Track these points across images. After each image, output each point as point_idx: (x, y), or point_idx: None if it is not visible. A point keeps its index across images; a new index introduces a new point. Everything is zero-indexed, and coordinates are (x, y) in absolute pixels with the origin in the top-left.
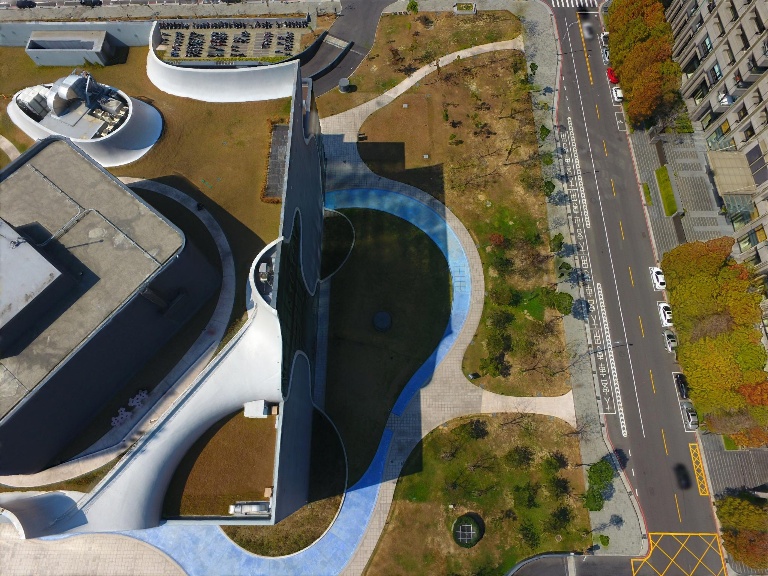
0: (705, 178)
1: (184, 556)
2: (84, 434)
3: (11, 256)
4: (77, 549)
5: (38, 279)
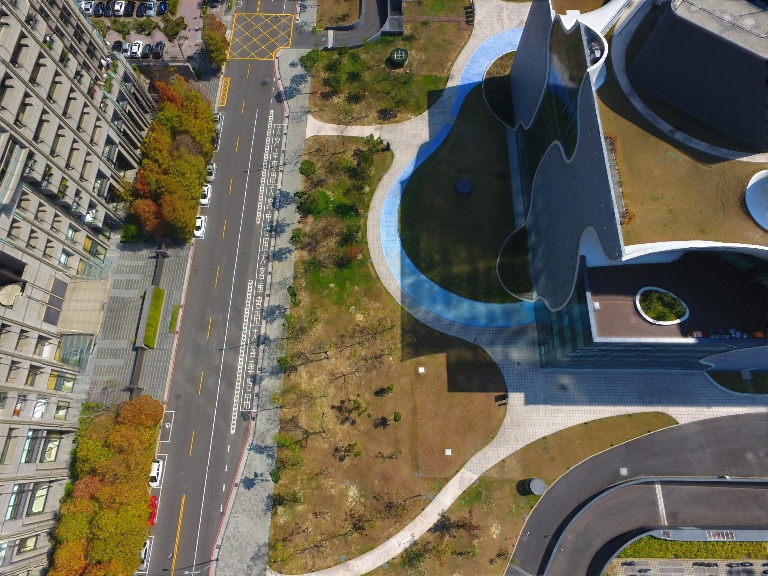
0: (100, 337)
1: None
2: None
3: None
4: None
5: None
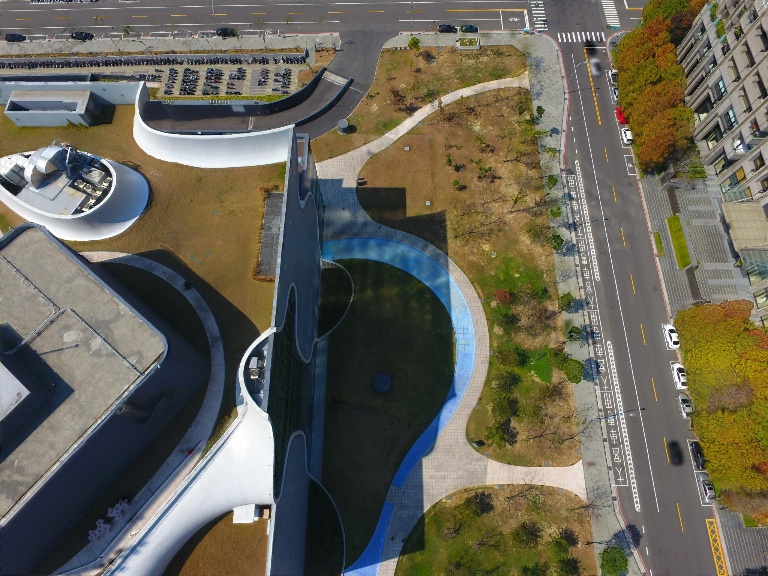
0: (719, 227)
1: None
2: (59, 549)
3: None
4: None
5: (4, 399)
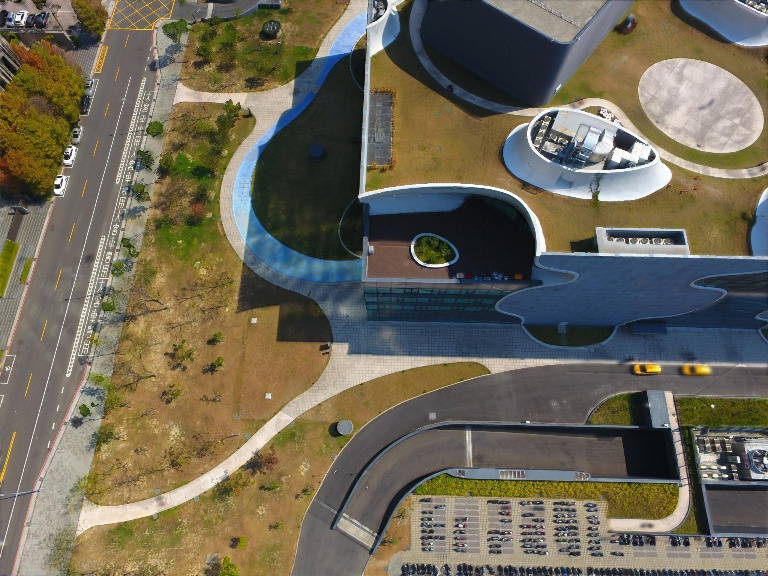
0: None
1: None
2: None
3: None
4: None
5: None
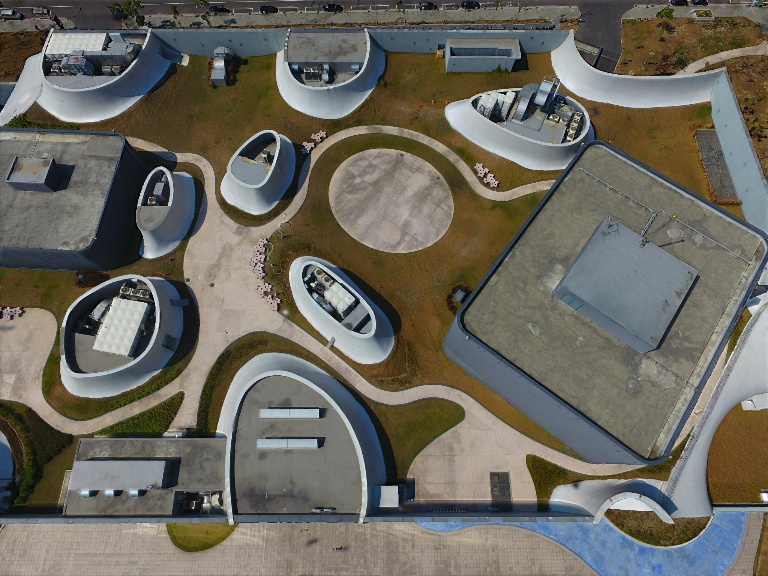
0: None
1: (579, 546)
2: None
3: (643, 255)
4: (474, 540)
5: (680, 277)
